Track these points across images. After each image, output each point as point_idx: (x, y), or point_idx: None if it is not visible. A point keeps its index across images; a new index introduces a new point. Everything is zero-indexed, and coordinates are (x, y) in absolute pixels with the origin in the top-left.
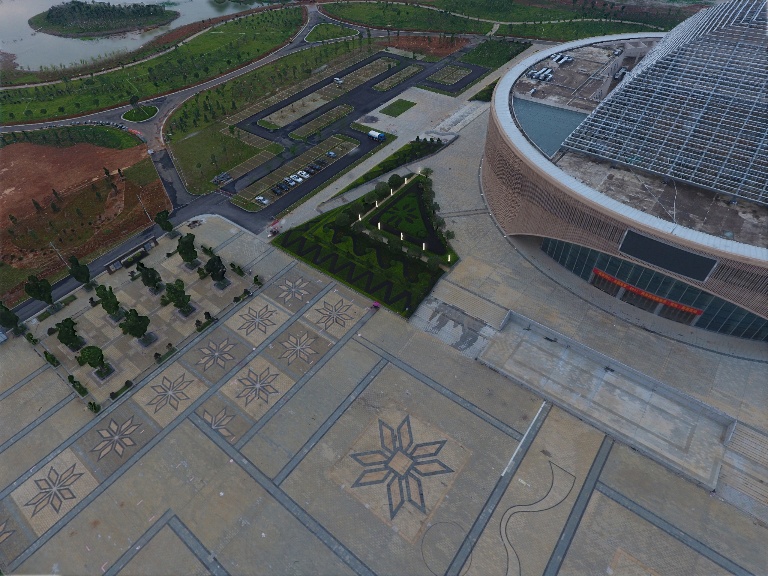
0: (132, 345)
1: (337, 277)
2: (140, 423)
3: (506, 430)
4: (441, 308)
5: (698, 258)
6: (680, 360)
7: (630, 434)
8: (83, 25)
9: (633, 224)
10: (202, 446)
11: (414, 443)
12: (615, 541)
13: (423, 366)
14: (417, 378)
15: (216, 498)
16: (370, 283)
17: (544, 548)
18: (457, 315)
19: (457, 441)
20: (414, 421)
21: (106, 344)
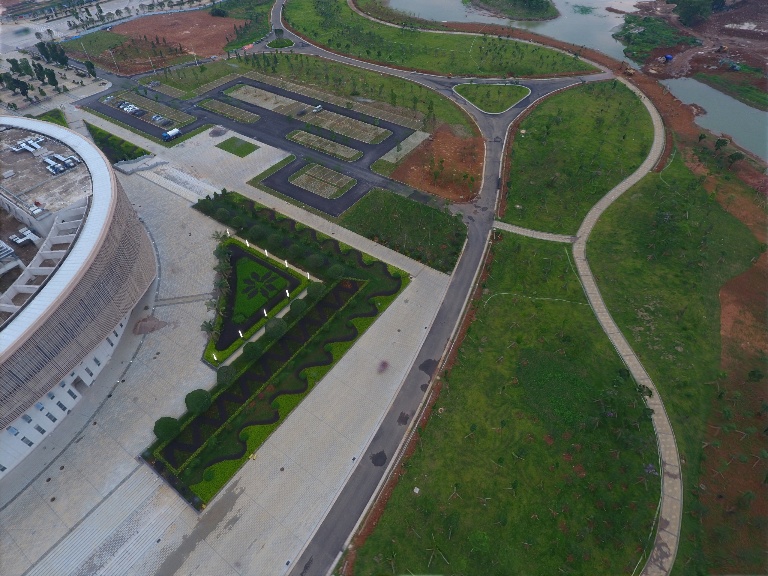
0: None
1: None
2: None
3: None
4: None
5: None
6: None
7: None
8: None
9: None
10: None
11: None
12: None
13: None
14: None
15: None
16: None
17: None
18: None
19: None
20: None
21: None
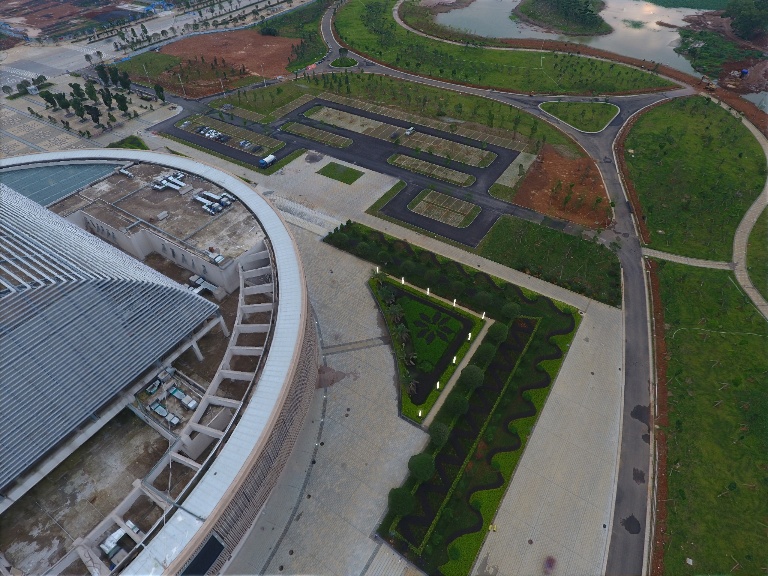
0: None
1: None
2: None
3: None
4: None
5: None
6: None
7: None
8: (536, 8)
9: None
10: None
11: None
12: None
13: None
14: None
15: None
16: None
17: None
18: None
19: None
20: None
21: None
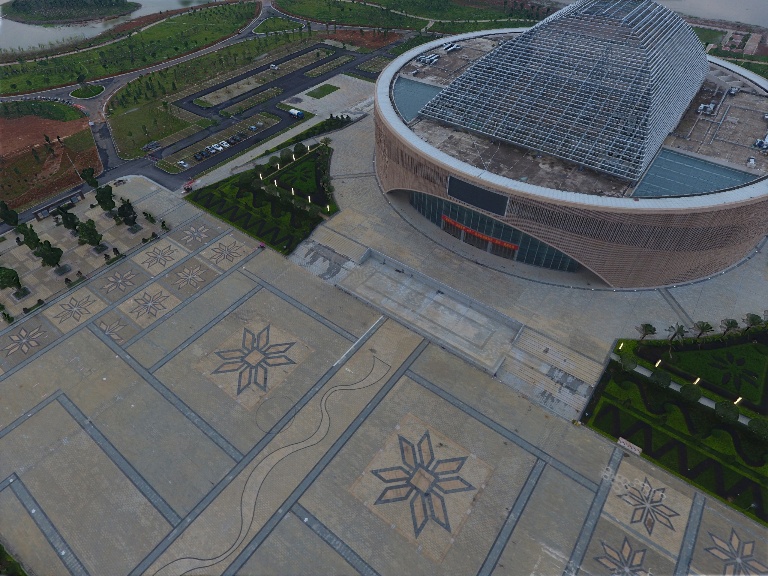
0: (48, 274)
1: (235, 224)
2: (46, 330)
3: (346, 335)
4: (316, 248)
5: (496, 196)
6: (496, 284)
7: (442, 337)
8: (46, 13)
9: (452, 170)
10: (95, 346)
11: (269, 344)
12: (408, 408)
13: (291, 290)
14: (284, 299)
15: (99, 382)
16: (261, 229)
17: (352, 413)
18: (328, 253)
19: (304, 343)
20: (273, 329)
21: (26, 273)
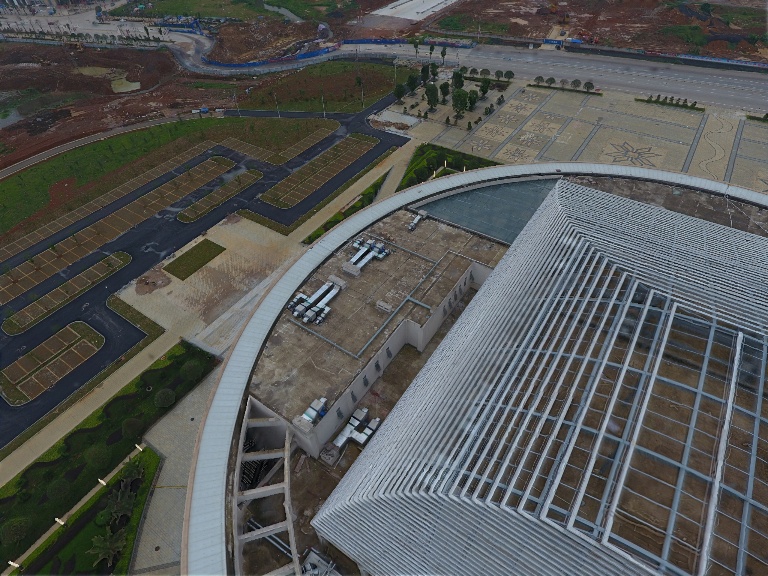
0: None
1: None
2: None
3: None
4: None
5: None
6: None
7: None
8: None
9: None
10: None
11: None
12: None
13: None
14: None
15: None
16: None
17: None
18: None
19: None
20: None
21: None
